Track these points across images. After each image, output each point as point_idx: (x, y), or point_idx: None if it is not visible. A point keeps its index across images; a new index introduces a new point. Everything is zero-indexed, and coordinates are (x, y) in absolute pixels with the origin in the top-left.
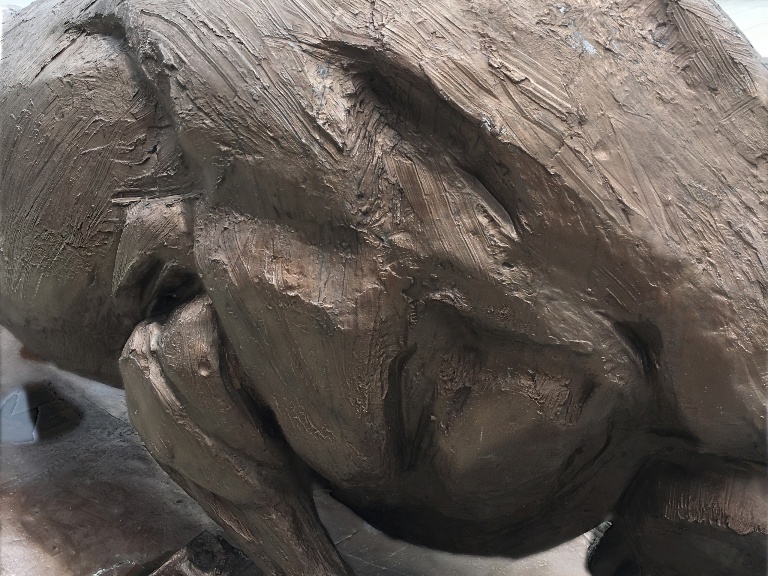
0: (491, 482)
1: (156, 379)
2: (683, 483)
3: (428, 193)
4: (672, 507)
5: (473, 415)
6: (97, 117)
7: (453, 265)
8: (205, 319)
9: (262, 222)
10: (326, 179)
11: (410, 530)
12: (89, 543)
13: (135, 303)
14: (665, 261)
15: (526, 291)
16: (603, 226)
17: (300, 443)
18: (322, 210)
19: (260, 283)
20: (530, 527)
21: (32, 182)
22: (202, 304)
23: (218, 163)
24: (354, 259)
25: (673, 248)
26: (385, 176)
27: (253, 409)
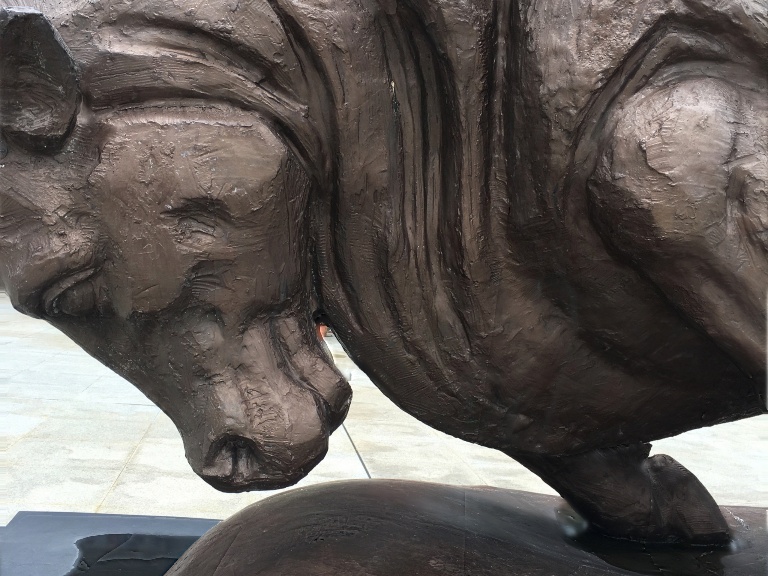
0: None
1: None
2: None
3: None
4: None
5: None
6: None
7: None
8: None
9: None
10: None
11: None
12: None
13: None
14: None
15: None
16: None
17: None
18: None
19: None
20: None
21: None
22: None
23: None
24: None
25: None
26: None
27: None
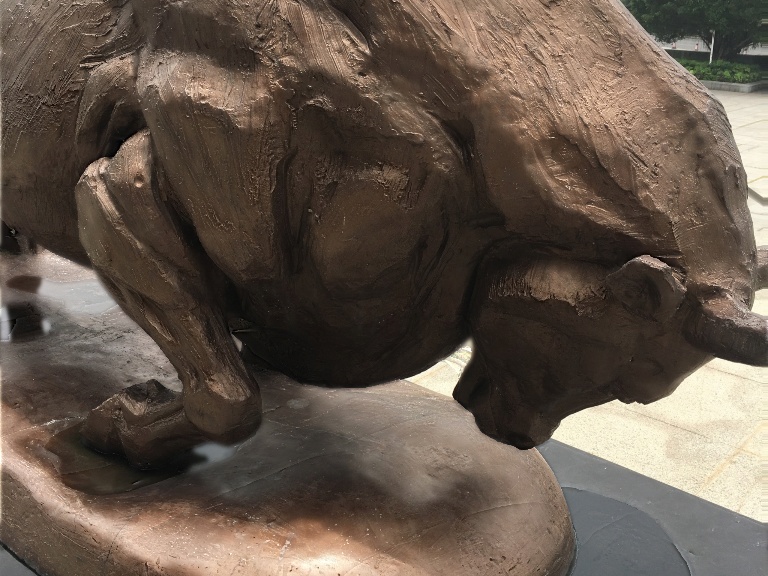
0: (355, 268)
1: (101, 194)
2: (503, 270)
3: (309, 25)
4: (494, 288)
5: (338, 203)
6: (74, 3)
7: (323, 76)
8: (143, 145)
9: (187, 54)
10: (233, 12)
11: (312, 368)
12: (46, 402)
13: (92, 149)
14: (476, 70)
15: (375, 93)
16: (430, 42)
17: (209, 240)
18: (229, 37)
19: (181, 97)
20: (402, 346)
21: (19, 58)
22: (142, 135)
23: (158, 12)
24: (252, 75)
25: (482, 61)
26: (278, 14)
27: (176, 221)
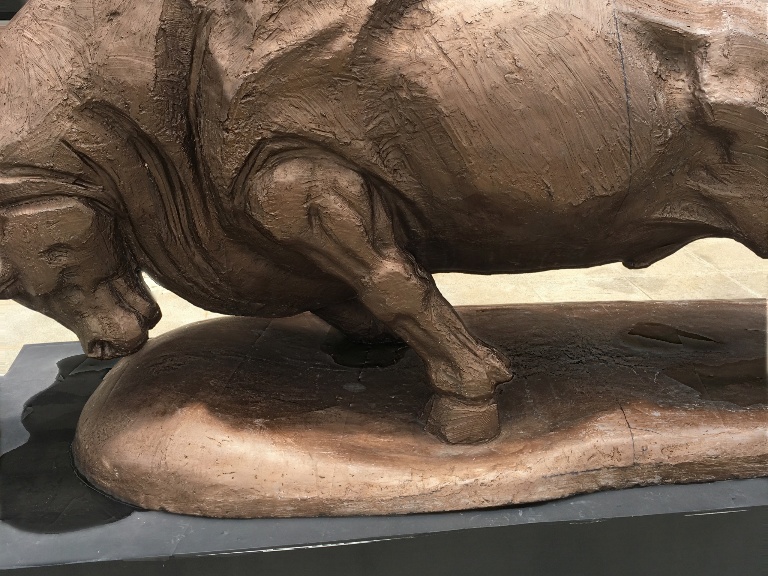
0: None
1: None
2: None
3: None
4: None
5: None
6: None
7: None
8: None
9: None
10: None
11: None
12: None
13: None
14: None
15: None
16: None
17: None
18: None
19: None
20: None
21: None
22: None
23: None
24: None
25: None
26: None
27: None
